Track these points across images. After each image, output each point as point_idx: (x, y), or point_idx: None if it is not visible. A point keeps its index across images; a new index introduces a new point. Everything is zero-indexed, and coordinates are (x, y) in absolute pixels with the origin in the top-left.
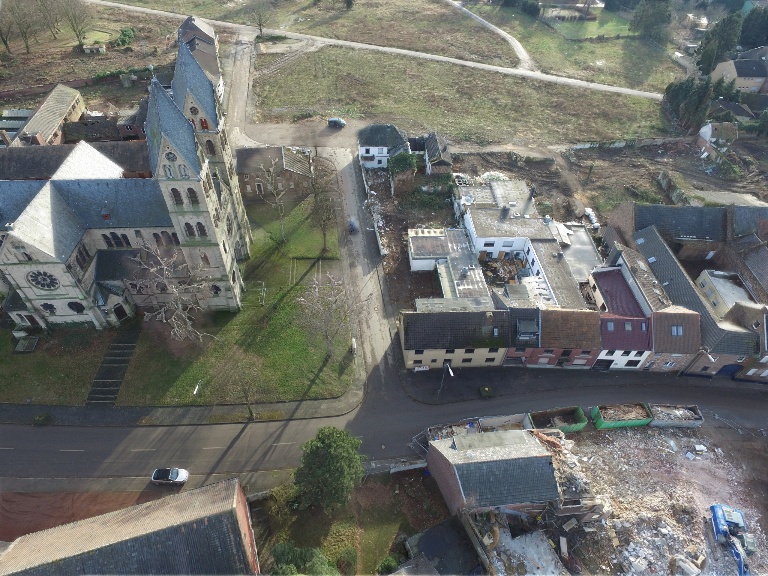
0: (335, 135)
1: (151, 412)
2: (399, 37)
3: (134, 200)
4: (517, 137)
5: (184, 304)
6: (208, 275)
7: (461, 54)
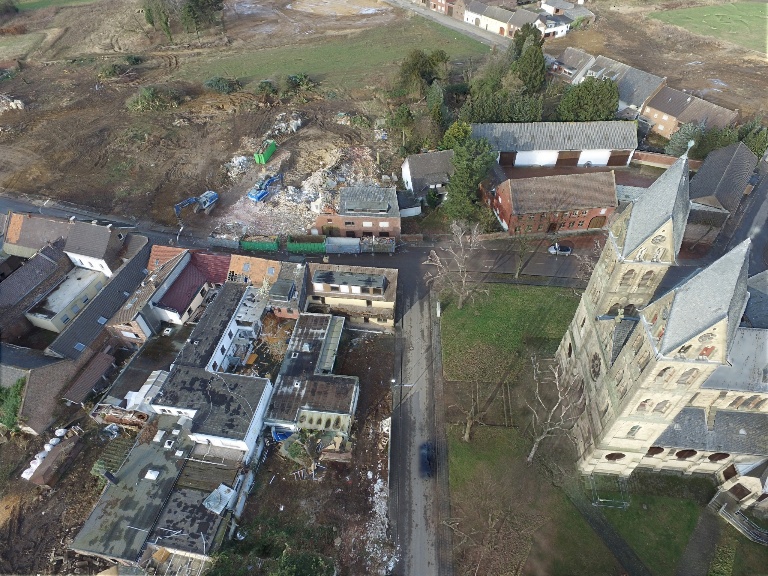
0: None
1: None
2: None
3: None
4: None
5: None
6: None
7: None
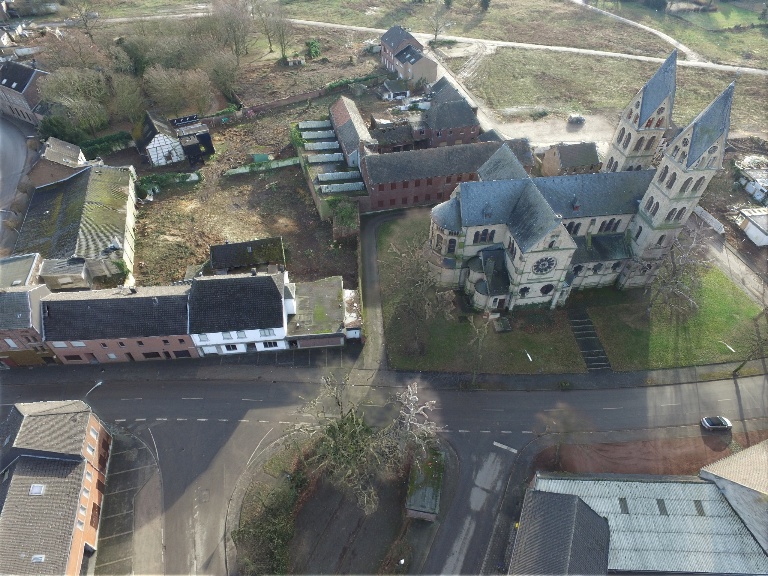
0: (582, 130)
1: (648, 374)
2: (556, 36)
3: (597, 192)
4: (744, 124)
5: (604, 284)
6: (651, 255)
7: (627, 49)
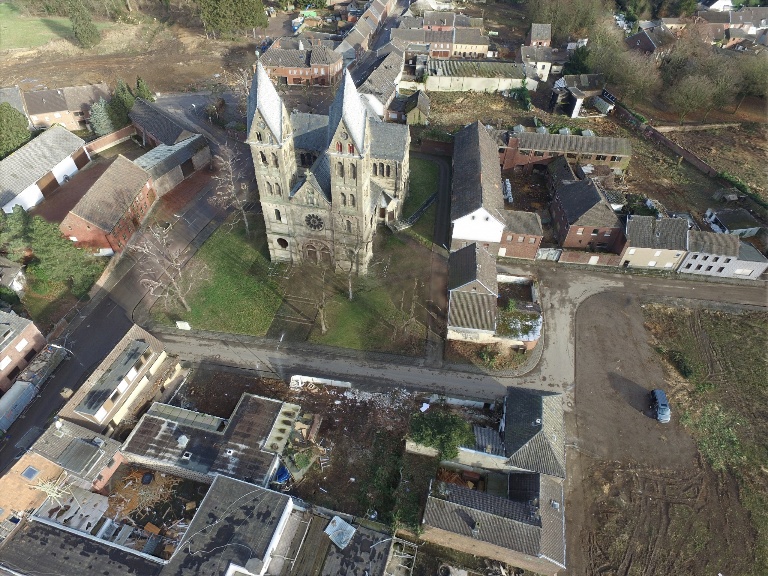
0: (618, 398)
1: (216, 225)
2: None
3: None
4: None
5: None
6: None
7: None
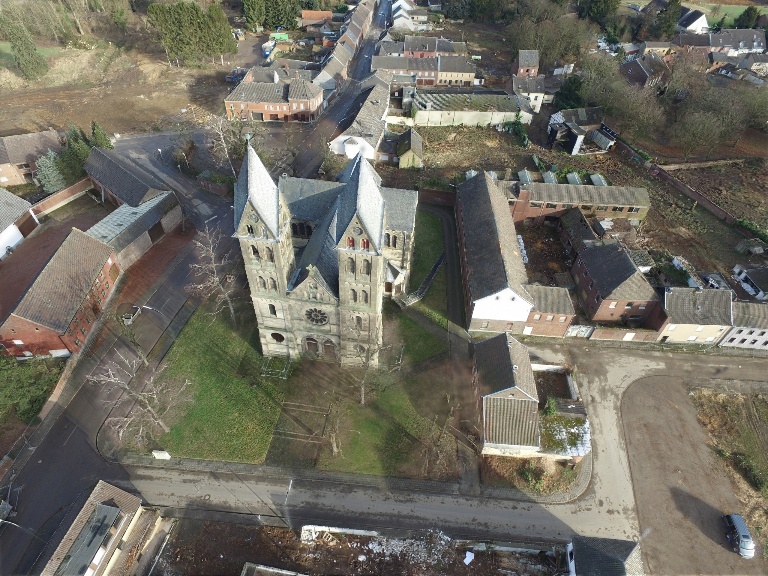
0: (689, 525)
1: (194, 305)
2: None
3: None
4: None
5: None
6: None
7: None
